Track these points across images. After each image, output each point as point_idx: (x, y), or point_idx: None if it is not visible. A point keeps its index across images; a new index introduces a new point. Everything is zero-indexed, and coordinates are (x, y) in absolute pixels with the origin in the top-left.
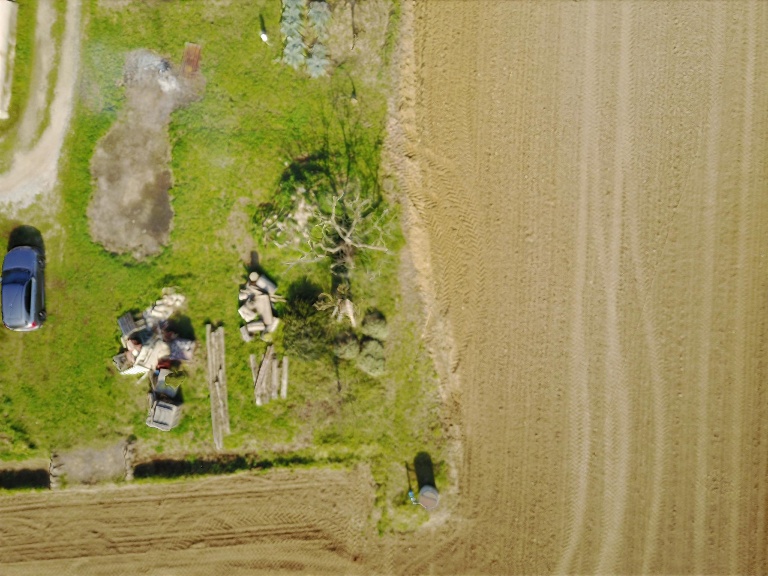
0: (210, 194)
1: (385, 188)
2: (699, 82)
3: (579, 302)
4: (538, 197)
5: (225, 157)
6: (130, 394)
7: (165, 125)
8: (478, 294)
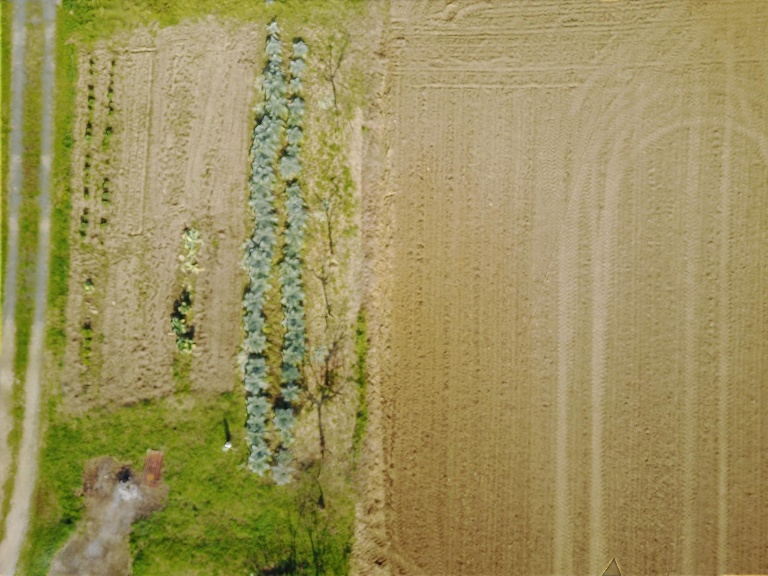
0: None
1: None
2: (672, 498)
3: None
4: None
5: (188, 569)
6: None
7: (126, 535)
8: None
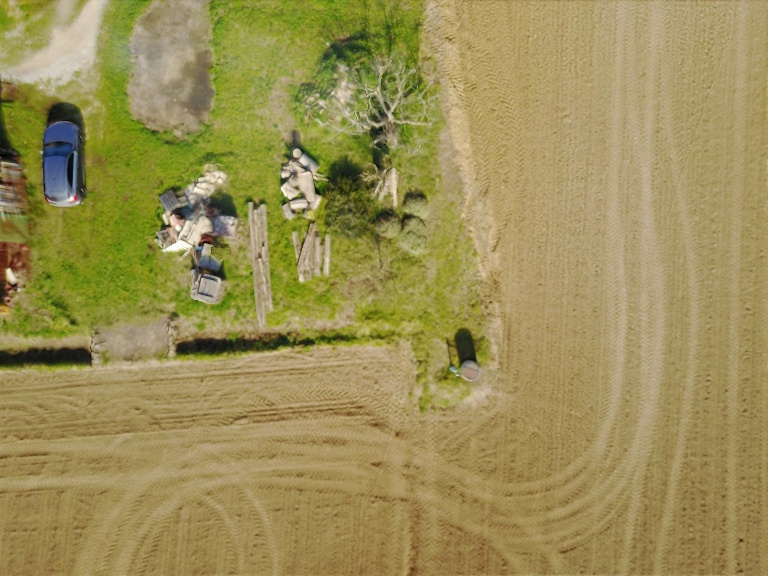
0: (252, 73)
1: (426, 70)
2: None
3: (616, 181)
4: (576, 78)
5: (267, 36)
6: (172, 272)
7: (206, 4)
8: (517, 174)
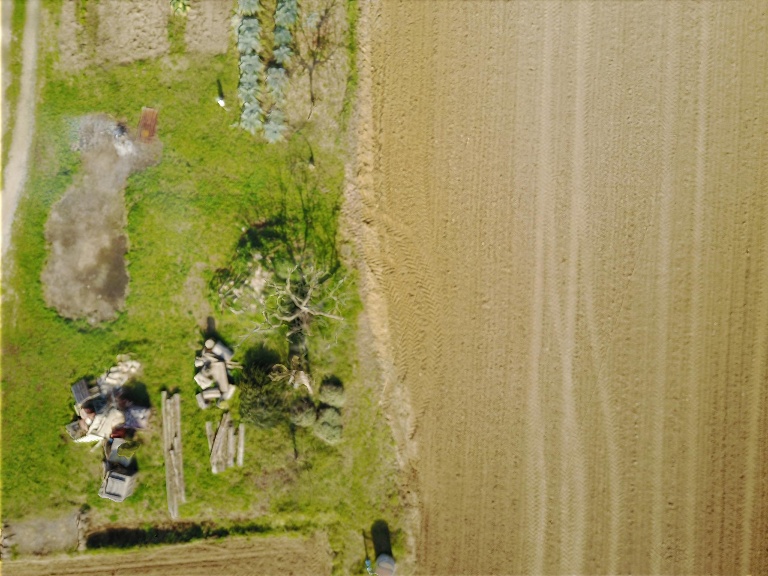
0: (166, 260)
1: (343, 254)
2: (652, 152)
3: (535, 369)
4: (495, 264)
5: (182, 222)
6: (83, 462)
7: (121, 190)
8: (435, 360)
